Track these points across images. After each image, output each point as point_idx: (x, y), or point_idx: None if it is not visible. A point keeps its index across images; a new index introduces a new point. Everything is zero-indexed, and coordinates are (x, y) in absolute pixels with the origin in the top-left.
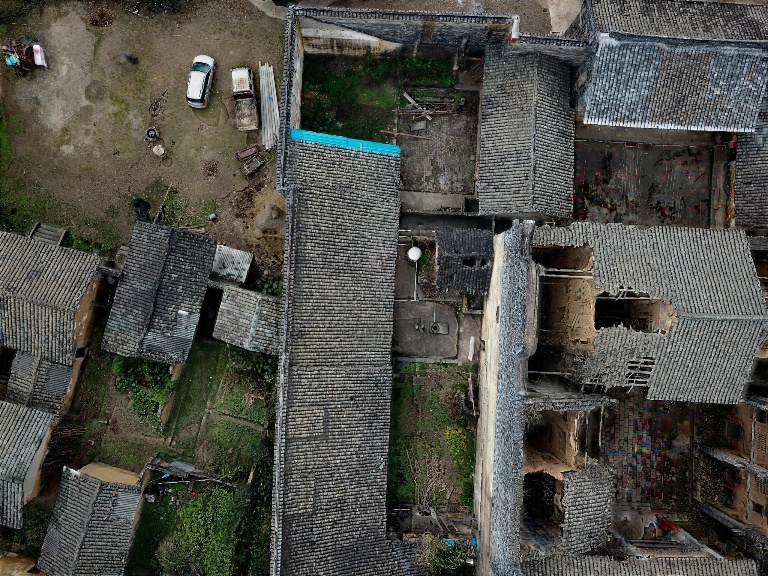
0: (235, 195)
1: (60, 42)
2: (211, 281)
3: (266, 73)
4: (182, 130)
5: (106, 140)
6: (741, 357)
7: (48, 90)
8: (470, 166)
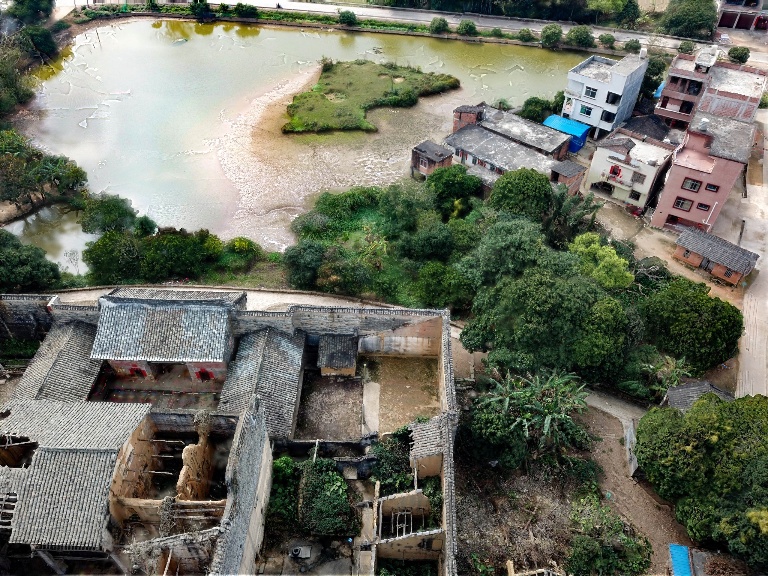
0: None
1: None
2: None
3: None
4: None
5: None
6: (96, 491)
7: None
8: None
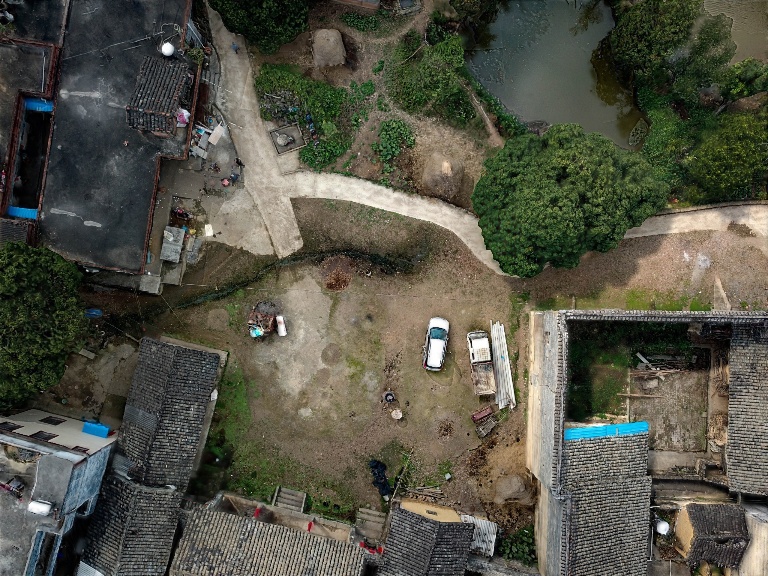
0: (468, 453)
1: (297, 306)
2: (470, 566)
3: (497, 332)
4: (416, 390)
5: (343, 402)
6: None
7: (286, 354)
8: (702, 423)
